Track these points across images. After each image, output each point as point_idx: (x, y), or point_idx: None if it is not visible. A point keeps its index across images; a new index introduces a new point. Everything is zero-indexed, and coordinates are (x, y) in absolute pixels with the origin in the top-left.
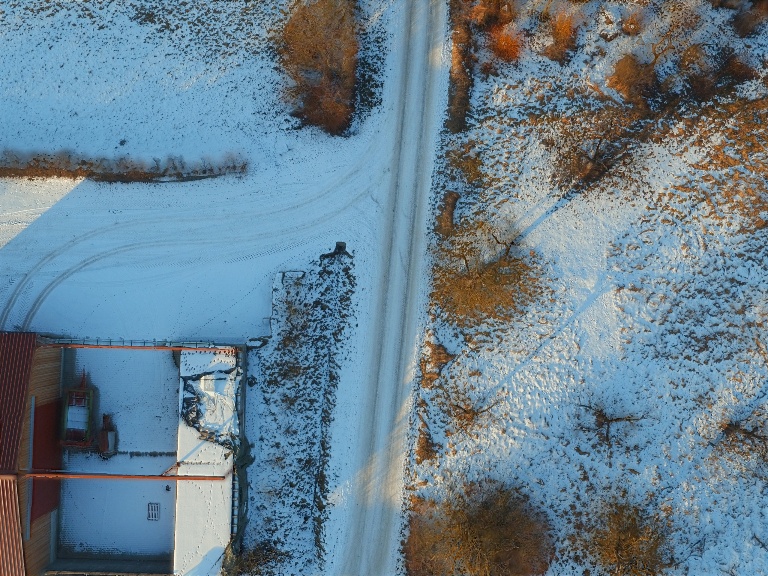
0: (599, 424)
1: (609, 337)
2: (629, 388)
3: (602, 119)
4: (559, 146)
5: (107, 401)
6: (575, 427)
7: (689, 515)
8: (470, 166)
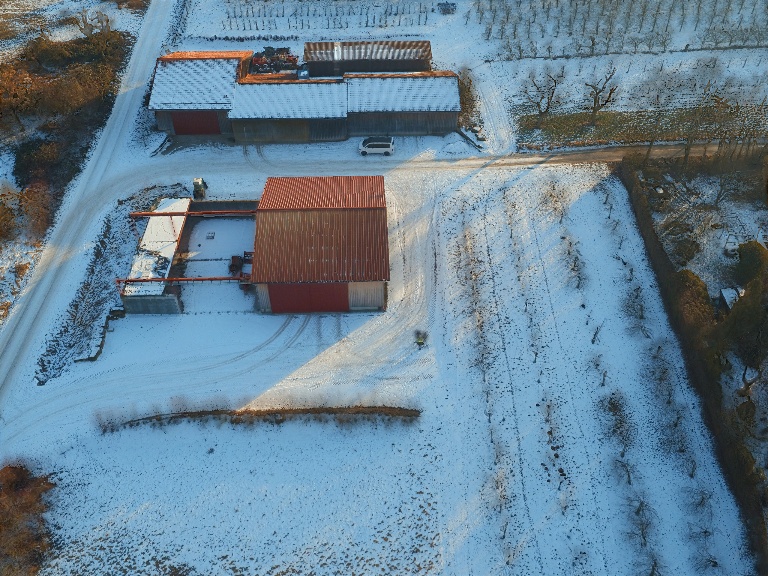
0: None
1: None
2: None
3: None
4: None
5: None
6: None
7: None
8: None
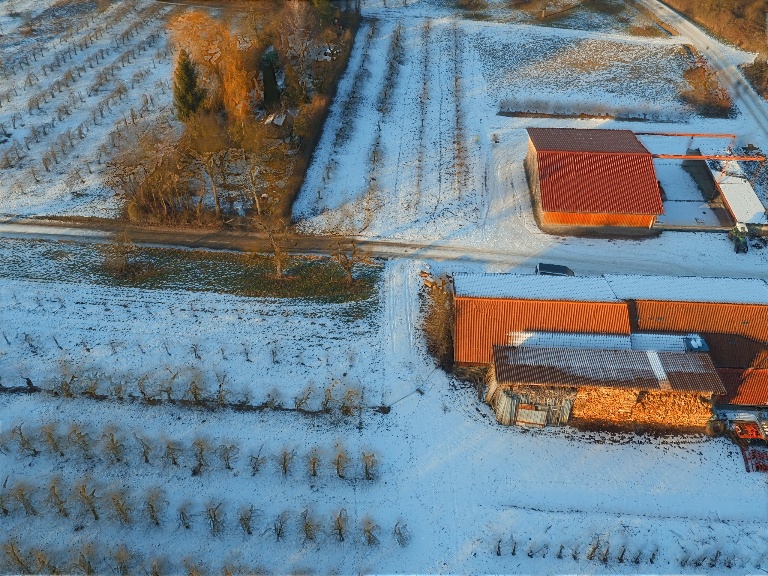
0: None
1: None
2: None
3: None
4: None
5: None
6: None
7: None
8: None
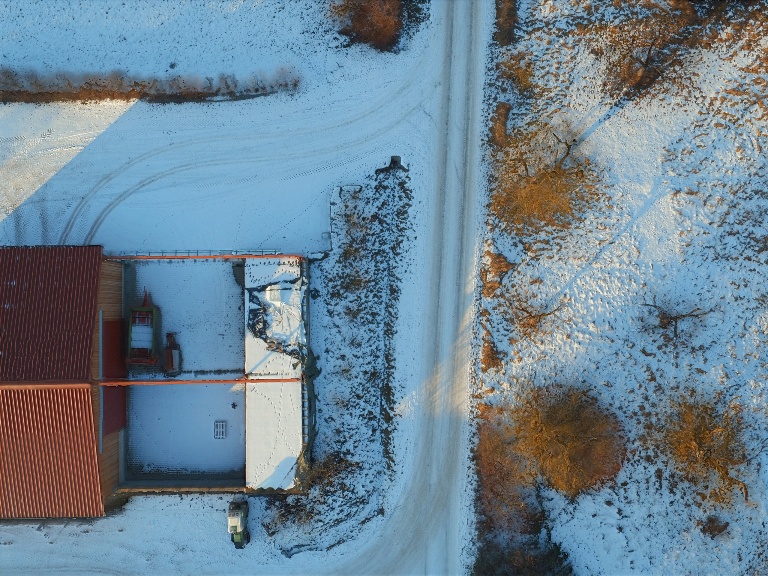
0: (663, 325)
1: (668, 241)
2: (691, 290)
3: (650, 27)
4: (609, 55)
5: (169, 321)
6: (639, 329)
7: (758, 411)
8: (521, 77)
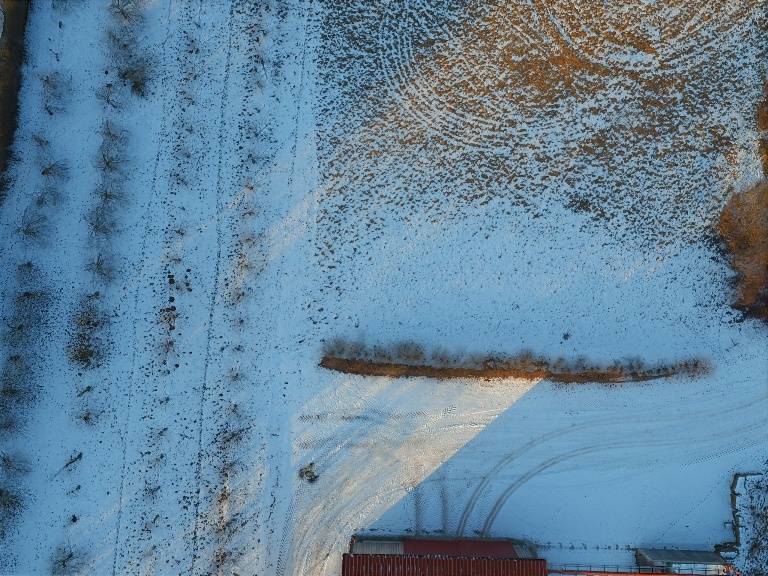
0: None
1: None
2: None
3: None
4: None
5: None
6: None
7: None
8: None
